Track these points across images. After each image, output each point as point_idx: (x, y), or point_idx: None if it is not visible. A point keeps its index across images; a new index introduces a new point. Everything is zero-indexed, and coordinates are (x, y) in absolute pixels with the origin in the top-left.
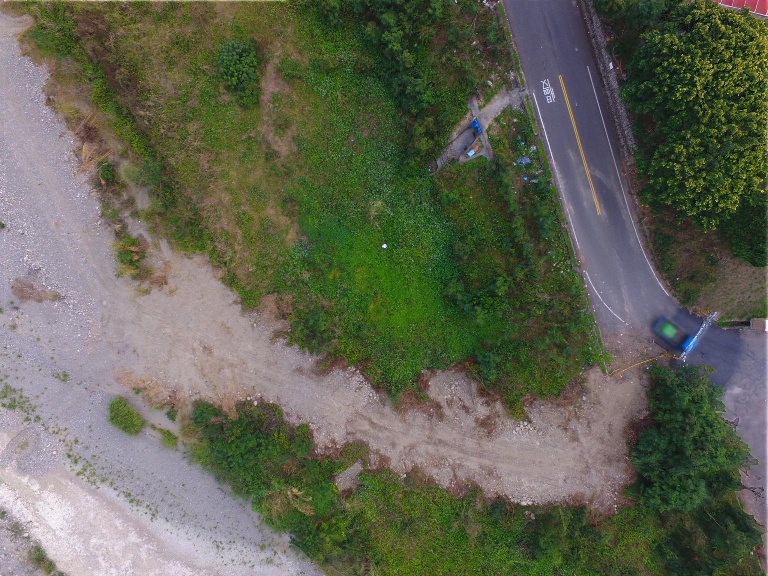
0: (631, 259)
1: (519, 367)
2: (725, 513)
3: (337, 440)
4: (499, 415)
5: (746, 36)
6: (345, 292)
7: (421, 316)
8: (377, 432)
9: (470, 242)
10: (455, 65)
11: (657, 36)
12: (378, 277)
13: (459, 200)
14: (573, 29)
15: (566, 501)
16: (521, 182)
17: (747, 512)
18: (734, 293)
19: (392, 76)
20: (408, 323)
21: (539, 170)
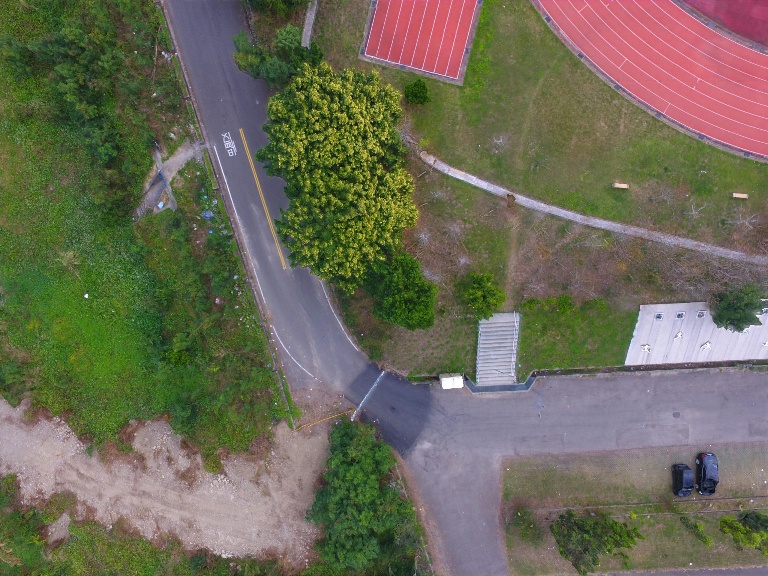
0: (318, 314)
1: (214, 420)
2: (407, 569)
3: (45, 491)
4: (199, 468)
5: (343, 106)
6: (45, 343)
7: (124, 367)
8: (84, 483)
9: (161, 295)
10: (128, 118)
11: (270, 102)
12: (80, 327)
13: (153, 252)
14: (254, 82)
15: (259, 555)
16: (206, 236)
17: (438, 566)
18: (415, 350)
19: (83, 125)
20: (111, 374)
21: (222, 224)
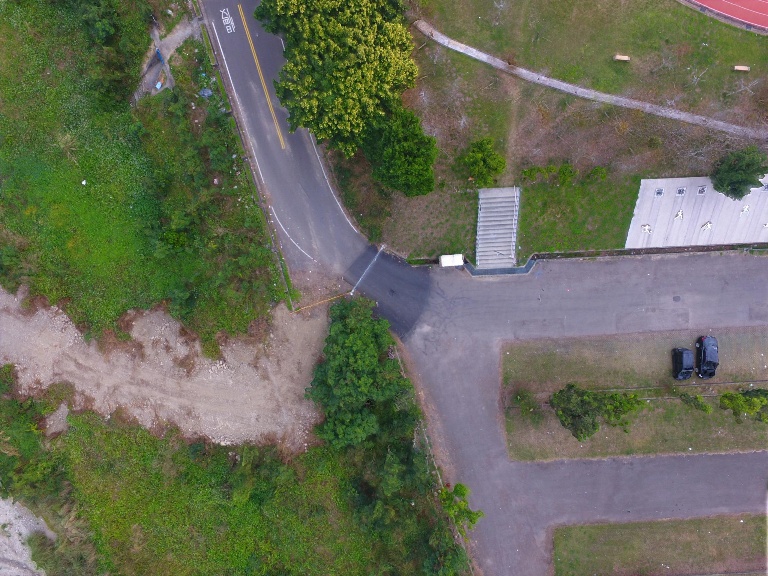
0: (317, 195)
1: (213, 305)
2: (406, 450)
3: (43, 381)
4: (198, 354)
5: None
6: (42, 229)
7: (122, 254)
8: (82, 373)
9: (159, 177)
10: None
11: None
12: (78, 214)
13: (151, 134)
14: None
15: (258, 440)
16: (205, 115)
17: (437, 451)
18: (415, 229)
19: None
20: (109, 262)
21: (220, 102)
